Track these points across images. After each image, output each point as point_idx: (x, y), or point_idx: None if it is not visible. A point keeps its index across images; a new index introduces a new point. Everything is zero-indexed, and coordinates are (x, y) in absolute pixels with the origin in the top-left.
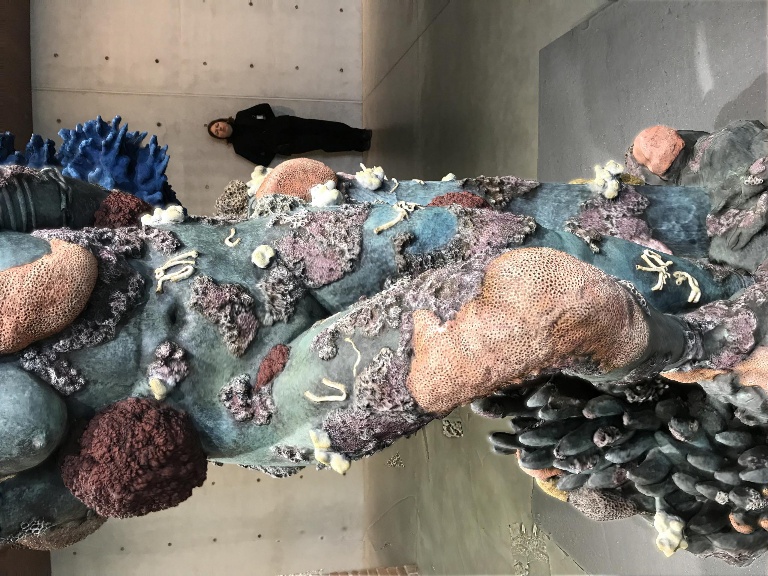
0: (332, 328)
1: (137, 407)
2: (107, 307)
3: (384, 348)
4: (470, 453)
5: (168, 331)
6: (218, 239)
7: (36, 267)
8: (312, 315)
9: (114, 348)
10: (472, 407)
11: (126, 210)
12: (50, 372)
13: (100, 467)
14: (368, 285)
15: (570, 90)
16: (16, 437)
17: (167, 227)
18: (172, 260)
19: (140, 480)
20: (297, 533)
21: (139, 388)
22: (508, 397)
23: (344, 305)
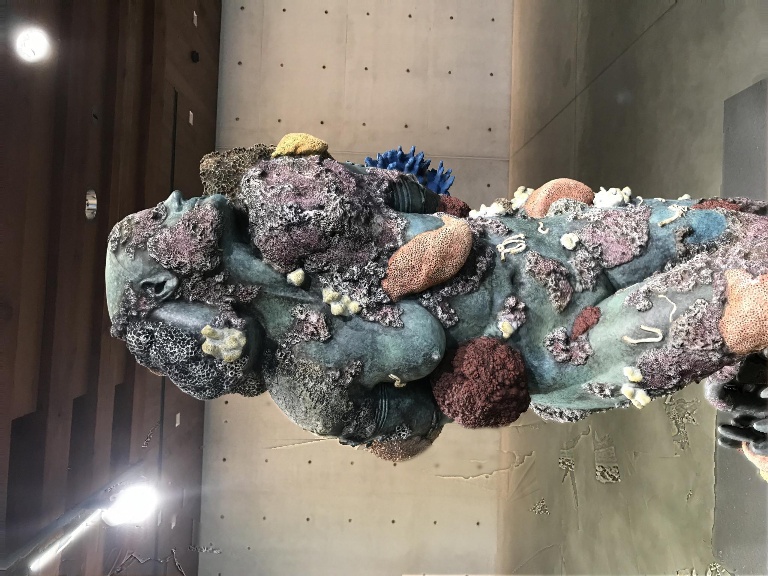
0: (645, 289)
1: (491, 342)
2: (473, 267)
3: (699, 299)
4: (629, 498)
5: (511, 289)
6: (533, 228)
7: (443, 231)
8: (607, 288)
9: (477, 297)
10: (707, 395)
11: (458, 207)
12: (438, 309)
13: (469, 382)
14: (651, 267)
15: (758, 135)
16: (423, 350)
17: (494, 218)
18: (508, 239)
19: (499, 393)
20: (442, 568)
21: (489, 330)
22: (738, 391)
23: (629, 284)
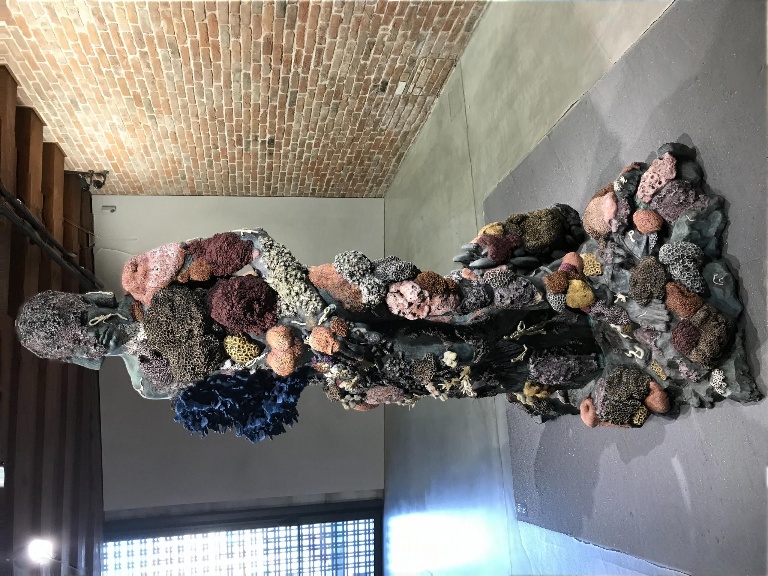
0: None
1: None
2: None
3: None
4: None
5: None
6: None
7: None
8: None
9: None
10: None
11: None
12: None
13: None
14: None
15: None
16: None
17: None
18: None
19: None
20: None
21: None
22: None
23: None
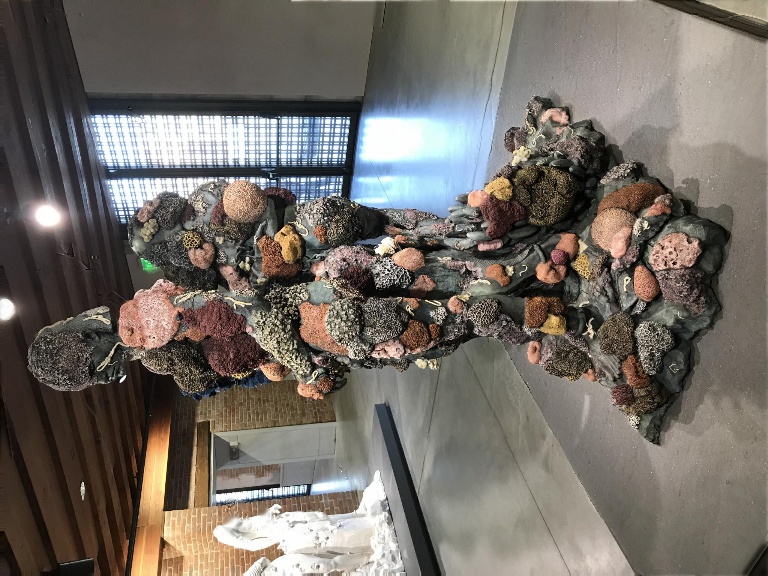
0: None
1: None
2: None
3: None
4: None
5: None
6: None
7: None
8: None
9: None
10: None
11: None
12: None
13: None
14: None
15: None
16: None
17: None
18: None
19: None
20: None
21: None
22: None
23: None
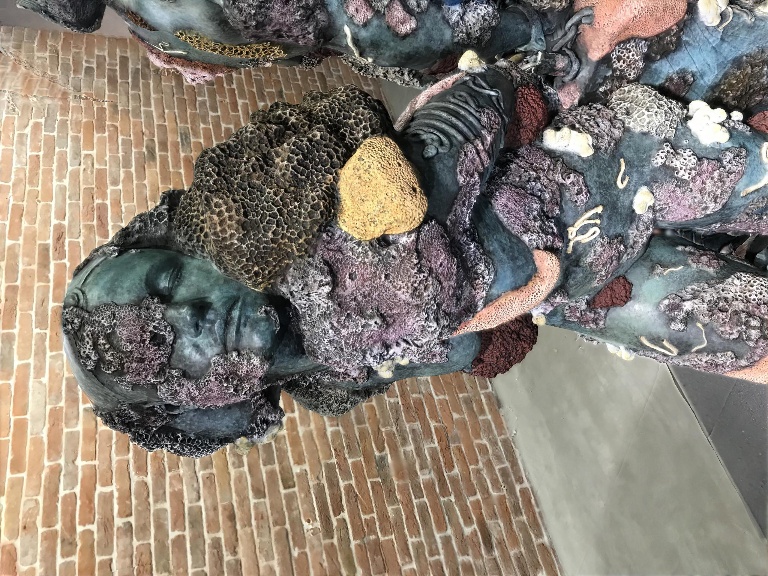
0: (690, 309)
1: (518, 326)
2: None
3: (731, 352)
4: None
5: (562, 281)
6: (612, 178)
7: (534, 294)
8: None
9: None
10: None
11: (535, 123)
12: None
13: (484, 364)
14: None
15: None
16: None
17: (575, 161)
18: (584, 219)
19: None
20: None
21: None
22: None
23: None
